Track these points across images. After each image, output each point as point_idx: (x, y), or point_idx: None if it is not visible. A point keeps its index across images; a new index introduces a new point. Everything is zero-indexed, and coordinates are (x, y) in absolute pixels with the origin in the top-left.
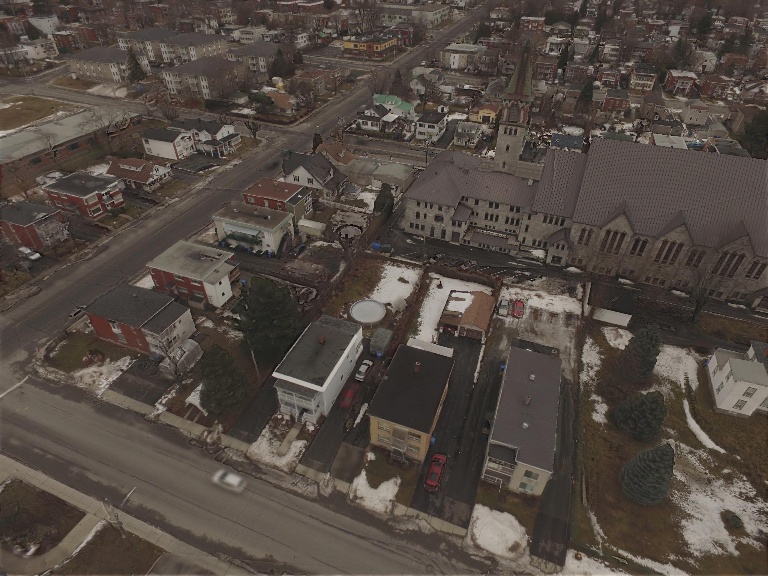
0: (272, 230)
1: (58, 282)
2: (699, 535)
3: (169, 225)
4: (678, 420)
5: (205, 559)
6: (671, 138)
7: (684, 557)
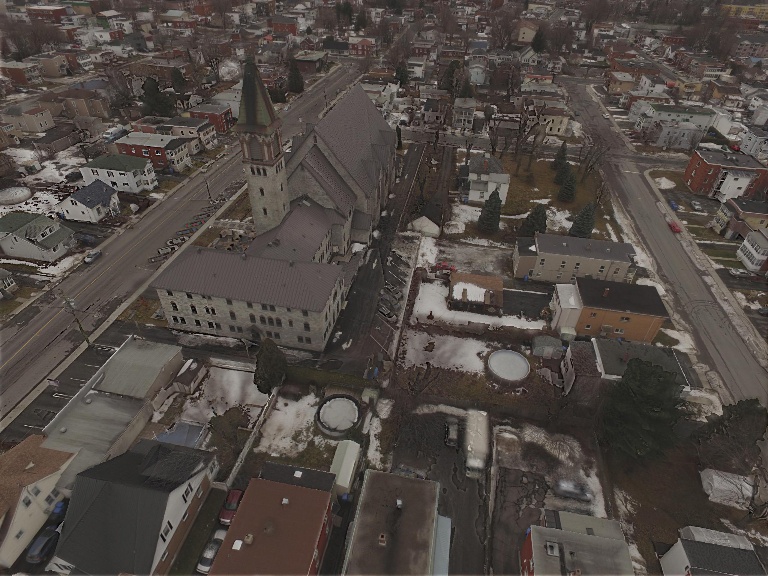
0: None
1: None
2: None
3: None
4: (516, 221)
5: None
6: (134, 137)
7: (604, 234)
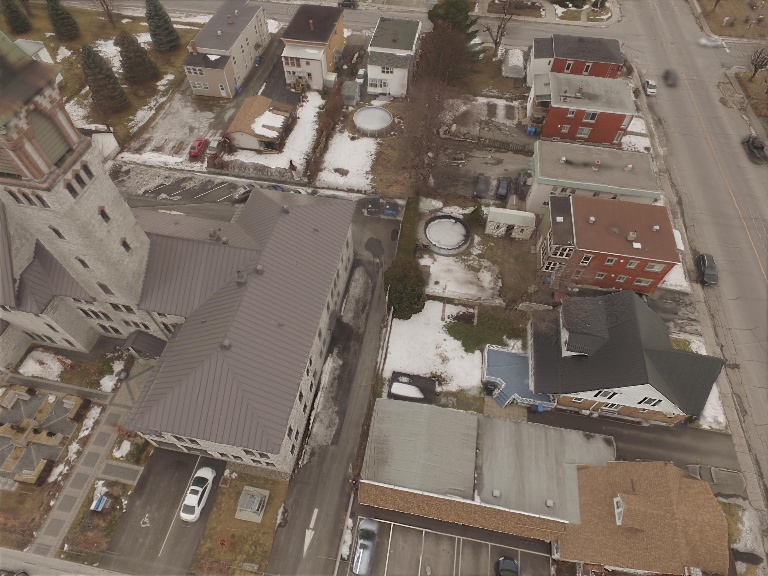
0: (539, 140)
1: (724, 114)
2: (146, 37)
3: (739, 212)
4: None
5: (415, 9)
6: None
7: None
